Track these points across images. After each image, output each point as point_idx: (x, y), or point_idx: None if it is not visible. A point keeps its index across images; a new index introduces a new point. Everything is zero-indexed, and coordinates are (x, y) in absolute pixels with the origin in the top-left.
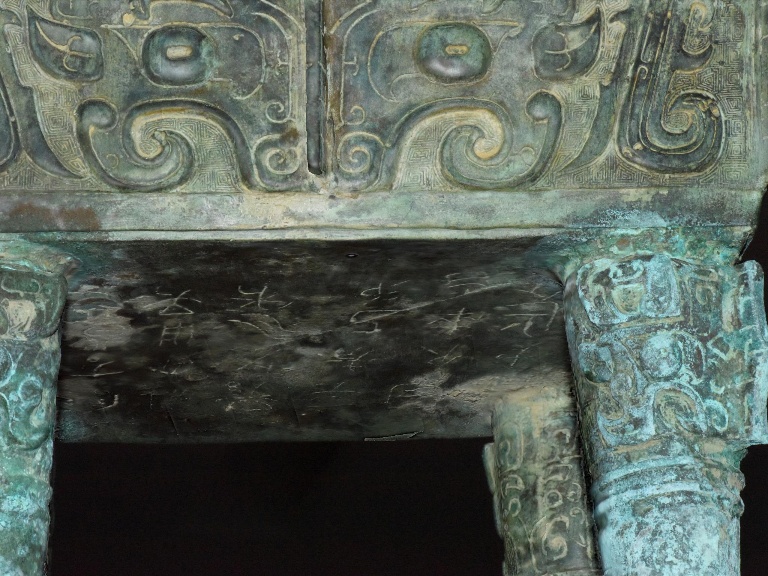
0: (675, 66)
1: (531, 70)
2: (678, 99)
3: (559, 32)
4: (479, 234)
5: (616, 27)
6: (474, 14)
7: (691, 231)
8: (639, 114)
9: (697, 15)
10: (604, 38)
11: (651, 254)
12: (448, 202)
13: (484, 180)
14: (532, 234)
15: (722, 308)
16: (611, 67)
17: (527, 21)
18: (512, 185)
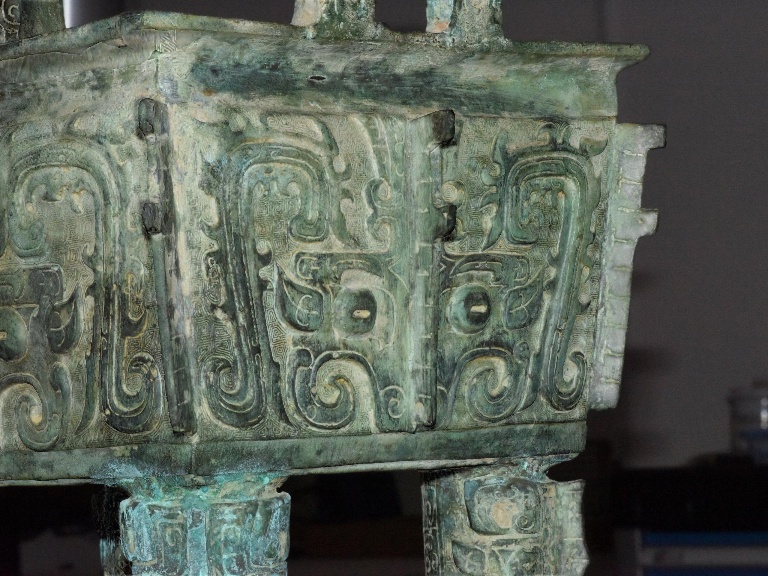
0: (124, 334)
1: (48, 345)
2: (130, 364)
3: (55, 311)
4: (56, 482)
5: (90, 300)
6: (11, 300)
7: (162, 479)
8: (105, 382)
9: (134, 283)
10: (84, 312)
11: (143, 499)
12: (30, 459)
13: (38, 443)
14: (82, 481)
15: (187, 547)
16: (91, 338)
17: (39, 302)
18: (50, 448)
